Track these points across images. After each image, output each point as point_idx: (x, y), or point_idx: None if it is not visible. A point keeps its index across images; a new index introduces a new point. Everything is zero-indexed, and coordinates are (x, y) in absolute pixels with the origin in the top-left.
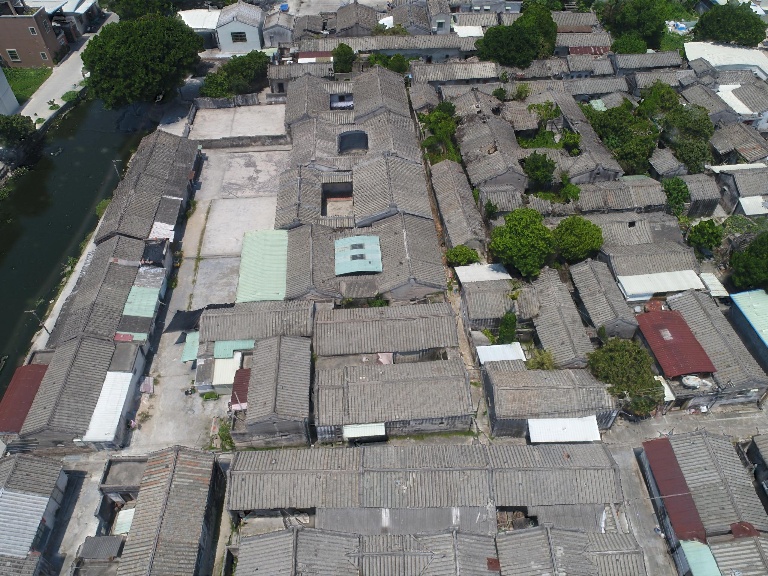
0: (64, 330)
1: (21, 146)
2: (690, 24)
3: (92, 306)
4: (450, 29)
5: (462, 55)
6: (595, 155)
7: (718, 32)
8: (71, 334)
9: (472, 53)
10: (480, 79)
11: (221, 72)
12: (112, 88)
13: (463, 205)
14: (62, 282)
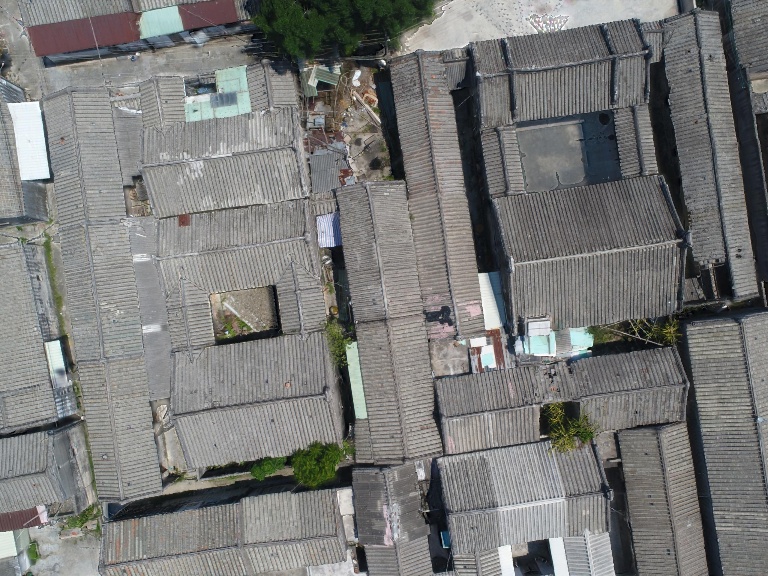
0: None
1: None
2: None
3: None
4: None
5: None
6: None
7: None
8: None
9: None
10: None
11: None
12: None
13: None
14: None
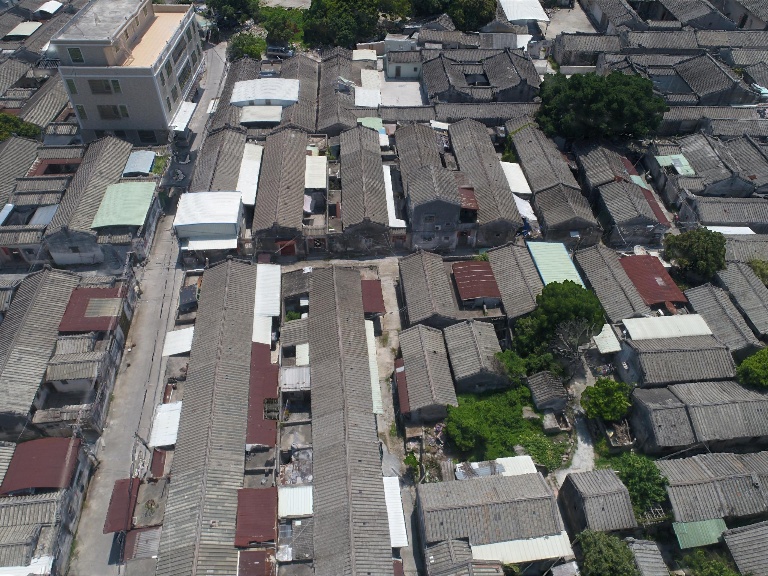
0: None
1: None
2: None
3: None
4: None
5: None
6: None
7: None
8: None
9: None
10: None
11: None
12: None
13: None
14: None
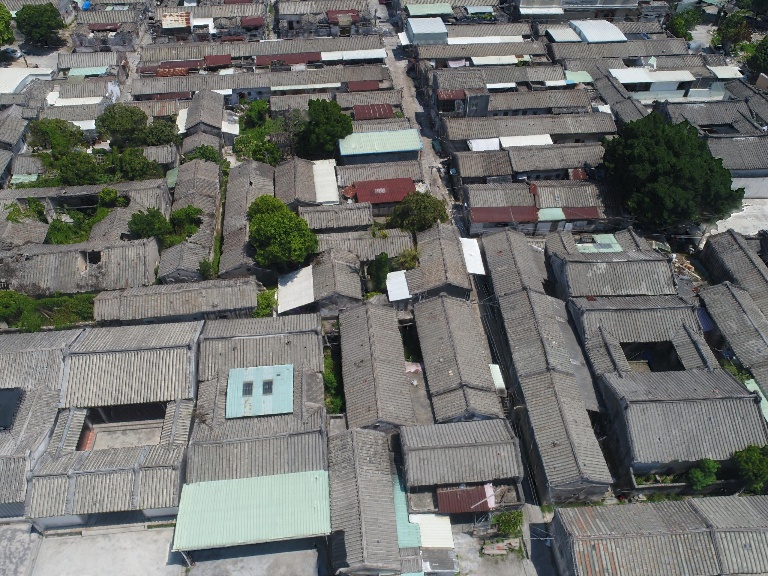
0: None
1: None
2: None
3: None
4: None
5: None
6: (136, 188)
7: None
8: None
9: None
10: None
11: None
12: None
13: (196, 288)
14: None
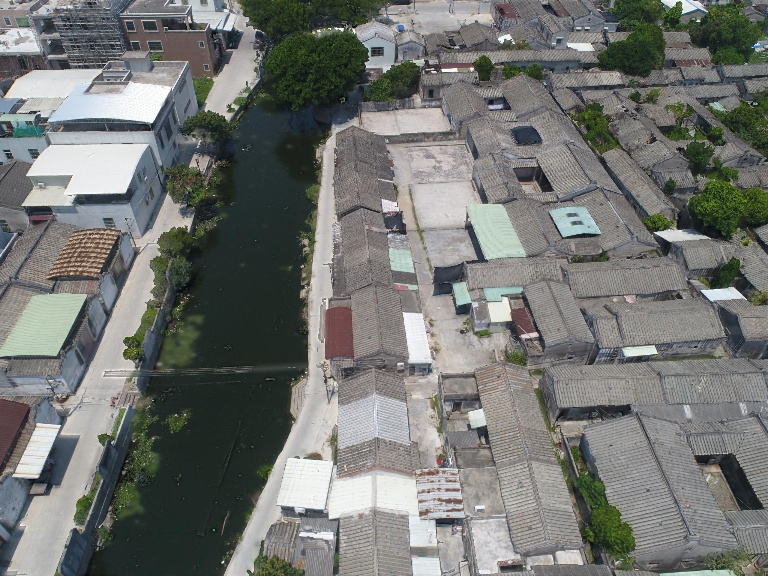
0: (349, 282)
1: (217, 142)
2: (763, 43)
3: (370, 262)
4: None
5: (580, 67)
6: (738, 144)
7: None
8: (360, 284)
9: (589, 65)
10: (608, 86)
11: (384, 79)
12: (300, 91)
13: (647, 183)
14: (305, 251)
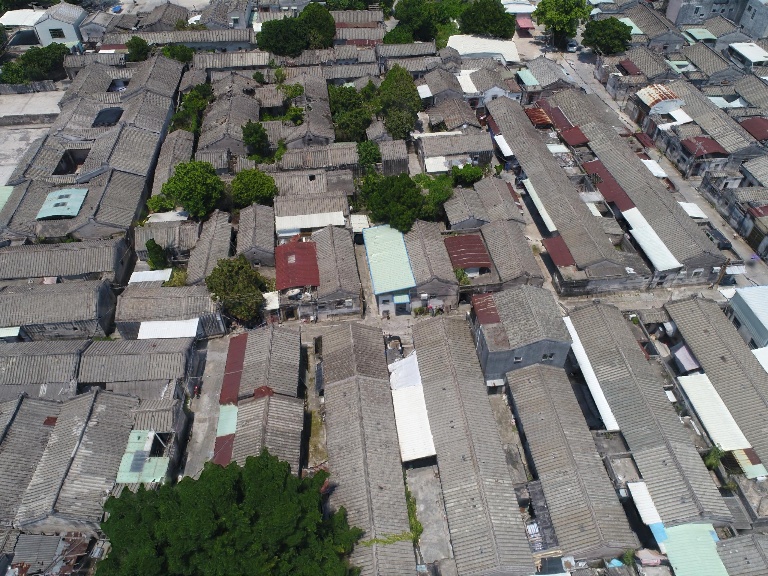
0: None
1: None
2: None
3: None
4: (250, 26)
5: (254, 48)
6: (313, 125)
7: (472, 25)
8: None
9: None
10: (255, 66)
11: (17, 61)
12: None
13: (172, 164)
14: None
